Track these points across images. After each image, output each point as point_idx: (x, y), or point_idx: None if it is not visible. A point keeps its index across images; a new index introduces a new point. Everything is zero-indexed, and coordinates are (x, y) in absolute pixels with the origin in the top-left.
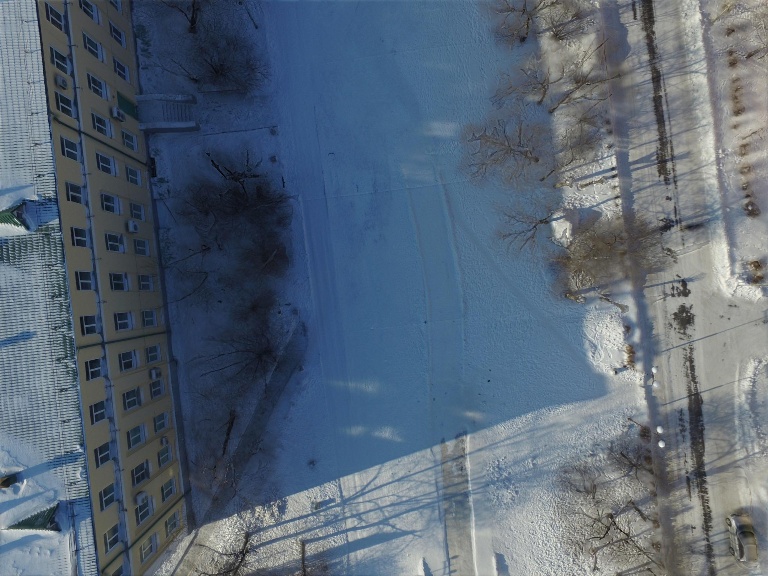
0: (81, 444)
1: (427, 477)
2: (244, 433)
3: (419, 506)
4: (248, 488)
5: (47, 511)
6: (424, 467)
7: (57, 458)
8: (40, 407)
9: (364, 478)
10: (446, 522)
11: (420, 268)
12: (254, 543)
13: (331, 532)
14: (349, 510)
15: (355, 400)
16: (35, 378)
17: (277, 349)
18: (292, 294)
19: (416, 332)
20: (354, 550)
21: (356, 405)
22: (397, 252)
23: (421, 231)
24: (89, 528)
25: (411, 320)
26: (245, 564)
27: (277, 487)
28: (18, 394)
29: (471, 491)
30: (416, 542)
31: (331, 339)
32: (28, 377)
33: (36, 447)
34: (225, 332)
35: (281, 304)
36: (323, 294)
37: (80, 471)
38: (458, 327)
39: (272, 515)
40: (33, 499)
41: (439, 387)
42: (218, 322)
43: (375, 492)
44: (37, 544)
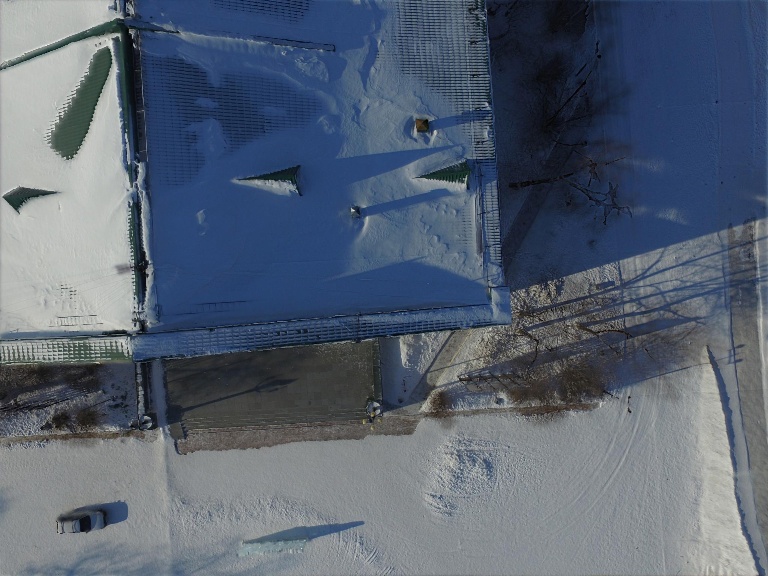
0: (489, 102)
1: (713, 262)
2: (520, 210)
3: (704, 292)
4: (523, 266)
5: (458, 165)
6: (710, 252)
7: (465, 113)
8: (450, 57)
9: (645, 261)
10: (732, 310)
11: (713, 46)
12: (527, 324)
13: (609, 316)
14: (628, 294)
15: (639, 180)
16: (446, 26)
17: (564, 119)
18: (579, 65)
19: (705, 112)
20: (632, 336)
21: (640, 185)
22: (688, 29)
23: (714, 8)
24: (494, 192)
25: (701, 100)
26: (516, 346)
27: (554, 266)
28: (430, 40)
29: (759, 278)
30: (699, 329)
31: (616, 115)
32: (439, 24)
33: (446, 99)
34: (509, 100)
35: (568, 74)
36: (610, 68)
37: (488, 130)
38: (749, 110)
39: (548, 295)
40: (443, 151)
41: (728, 170)
42: (503, 88)
43: (657, 276)
44: (444, 201)
